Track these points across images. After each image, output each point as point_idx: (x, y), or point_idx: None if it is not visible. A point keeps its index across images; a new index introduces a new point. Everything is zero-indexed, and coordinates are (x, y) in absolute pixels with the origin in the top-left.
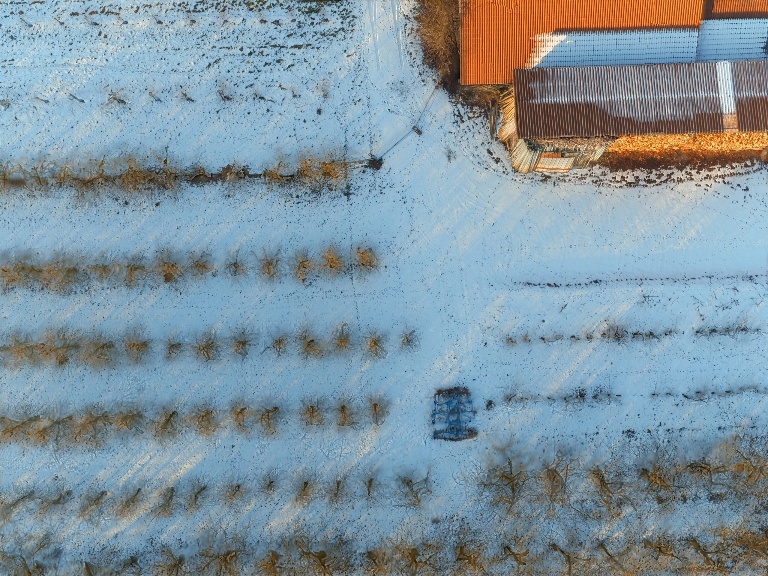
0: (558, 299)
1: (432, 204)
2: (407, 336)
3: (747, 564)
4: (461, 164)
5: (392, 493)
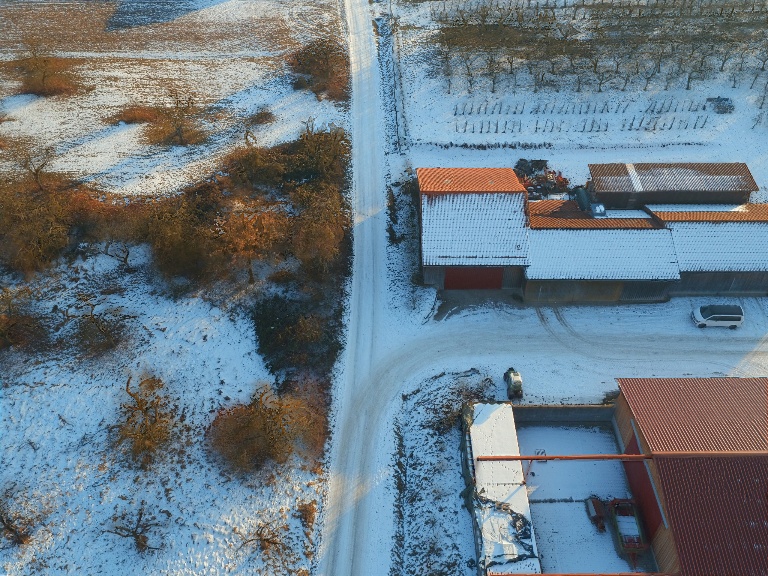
0: (683, 139)
1: (766, 171)
2: (761, 118)
3: (571, 68)
4: (757, 185)
5: (746, 75)
